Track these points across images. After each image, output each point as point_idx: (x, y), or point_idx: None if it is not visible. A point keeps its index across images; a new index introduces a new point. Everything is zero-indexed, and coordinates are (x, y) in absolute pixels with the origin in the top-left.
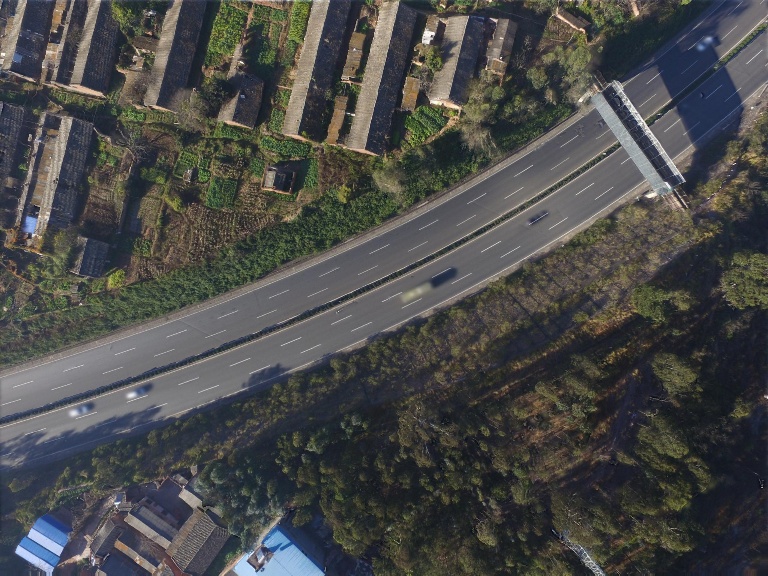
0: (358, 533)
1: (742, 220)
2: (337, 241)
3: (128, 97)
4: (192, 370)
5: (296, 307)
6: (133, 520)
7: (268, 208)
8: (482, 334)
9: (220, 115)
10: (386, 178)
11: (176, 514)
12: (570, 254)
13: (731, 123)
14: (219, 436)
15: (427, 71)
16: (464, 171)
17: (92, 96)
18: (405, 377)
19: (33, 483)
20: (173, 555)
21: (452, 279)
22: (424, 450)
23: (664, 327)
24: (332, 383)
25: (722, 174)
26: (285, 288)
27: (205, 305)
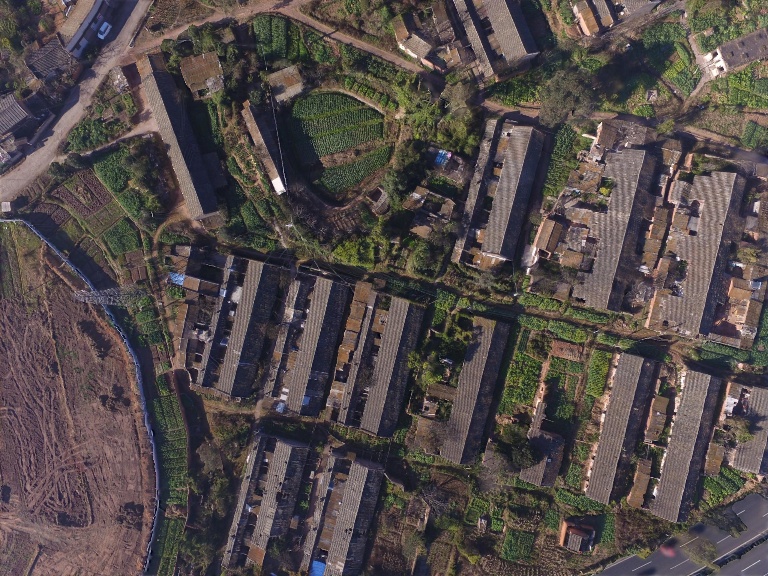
0: None
1: None
2: None
3: (423, 447)
4: None
5: None
6: None
7: (565, 562)
8: None
9: (522, 474)
10: None
11: None
12: None
13: None
14: None
15: (730, 437)
16: None
17: None
18: None
19: None
20: None
21: None
22: None
23: None
24: None
25: None
26: None
27: None
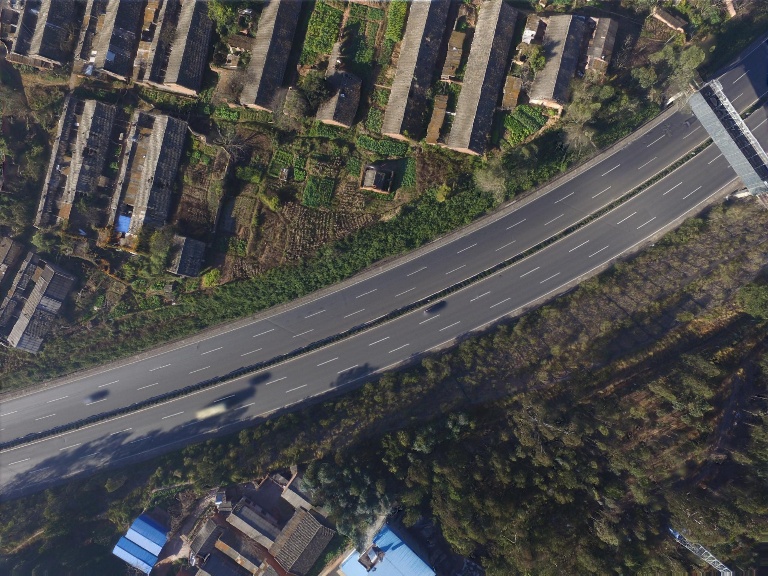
0: (475, 532)
1: None
2: (426, 240)
3: (224, 96)
4: (279, 370)
5: (384, 306)
6: (235, 520)
7: (366, 207)
8: (581, 333)
9: (318, 114)
10: (493, 177)
11: (275, 514)
12: (663, 253)
13: None
14: (314, 436)
15: (528, 70)
16: (553, 170)
17: (183, 95)
18: (504, 376)
19: (125, 483)
20: (276, 555)
21: (540, 278)
22: (542, 449)
23: (767, 326)
24: (427, 382)
25: None
26: (373, 287)
27: (292, 304)
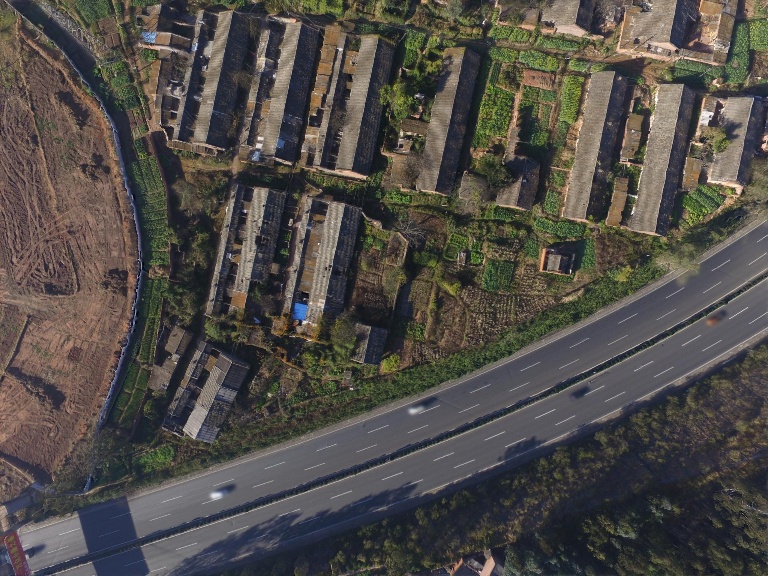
0: None
1: None
2: (590, 313)
3: (399, 181)
4: (447, 445)
5: (549, 379)
6: None
7: (546, 289)
8: (762, 408)
9: (499, 199)
10: (687, 263)
11: None
12: None
13: None
14: (497, 516)
15: (707, 151)
16: None
17: (351, 178)
18: (690, 453)
19: None
20: None
21: (702, 346)
22: (765, 539)
23: None
24: (605, 458)
25: None
26: (536, 360)
27: (456, 380)
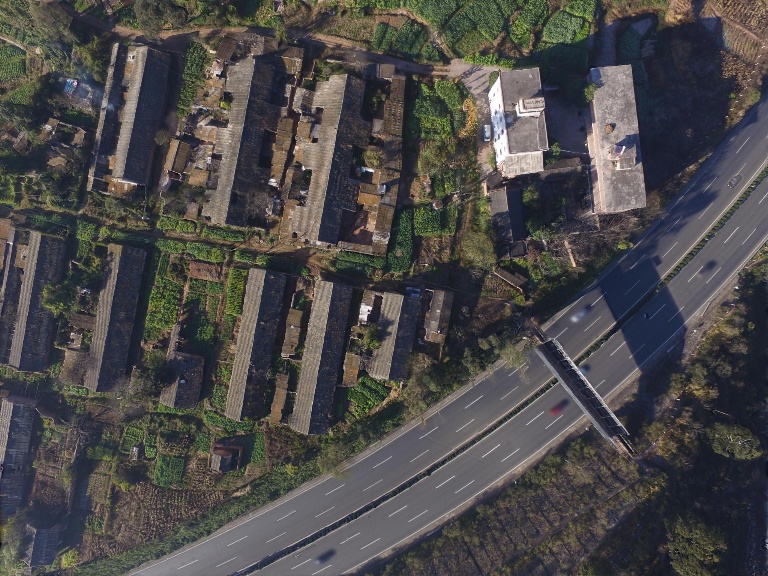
0: None
1: (687, 468)
2: (292, 488)
3: (68, 378)
4: None
5: (255, 554)
6: None
7: (217, 484)
8: None
9: (162, 398)
10: None
11: None
12: (522, 496)
13: (675, 345)
14: None
15: None
16: None
17: None
18: None
19: None
20: None
21: (409, 517)
22: None
23: None
24: None
25: (666, 413)
26: (243, 535)
27: (164, 556)
